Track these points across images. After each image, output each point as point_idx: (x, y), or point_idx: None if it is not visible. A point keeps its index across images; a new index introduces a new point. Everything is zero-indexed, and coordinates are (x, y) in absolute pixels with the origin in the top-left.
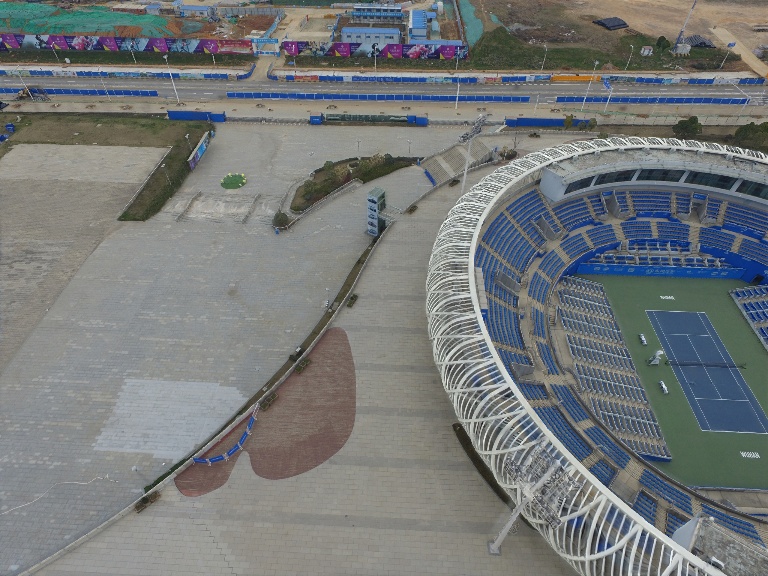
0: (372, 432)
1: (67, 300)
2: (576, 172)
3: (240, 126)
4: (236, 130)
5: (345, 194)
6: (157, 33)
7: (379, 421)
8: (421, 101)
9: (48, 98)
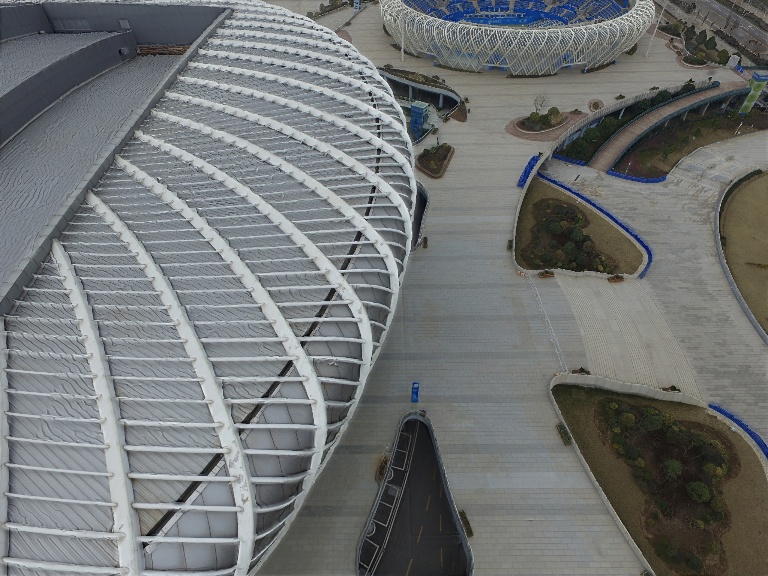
0: (359, 47)
1: None
2: None
3: None
4: None
5: (342, 10)
6: None
7: (362, 45)
8: None
9: None
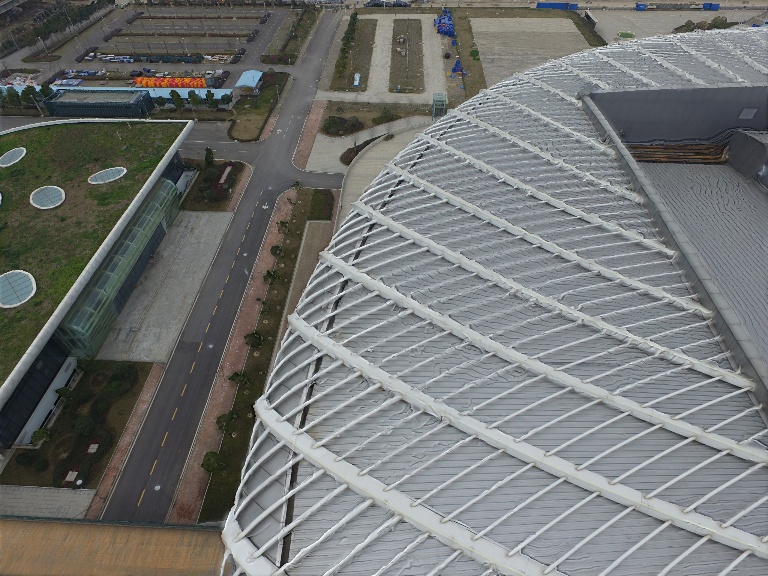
0: None
1: None
2: None
3: None
4: None
5: None
6: None
7: None
8: None
9: (431, 2)
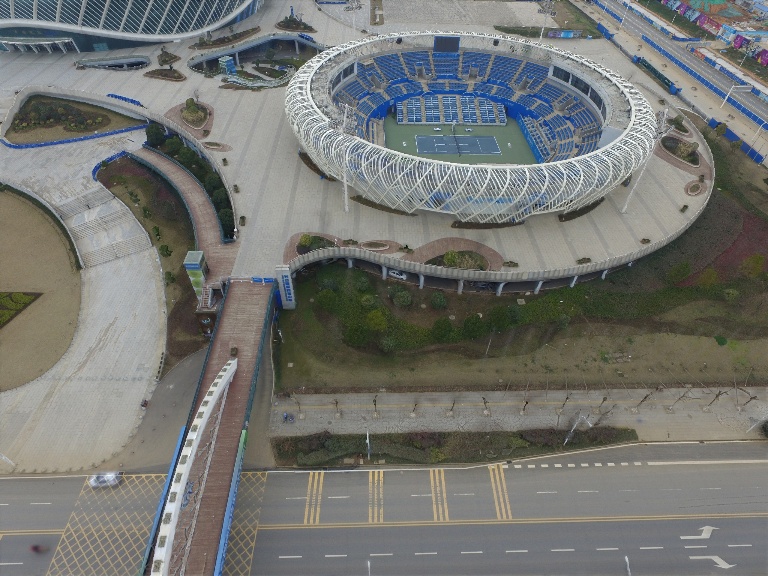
0: None
1: (442, 25)
2: (562, 62)
3: (608, 44)
4: (602, 43)
5: None
6: (698, 5)
7: None
8: (717, 95)
9: (592, 5)
